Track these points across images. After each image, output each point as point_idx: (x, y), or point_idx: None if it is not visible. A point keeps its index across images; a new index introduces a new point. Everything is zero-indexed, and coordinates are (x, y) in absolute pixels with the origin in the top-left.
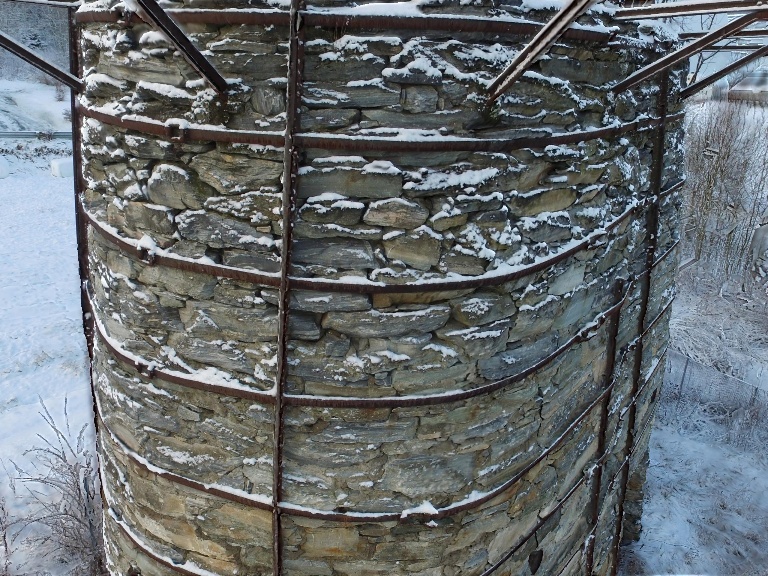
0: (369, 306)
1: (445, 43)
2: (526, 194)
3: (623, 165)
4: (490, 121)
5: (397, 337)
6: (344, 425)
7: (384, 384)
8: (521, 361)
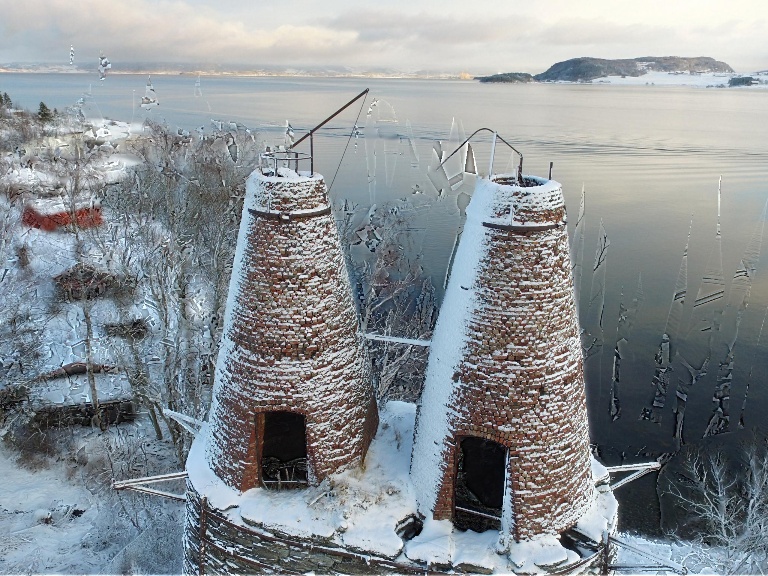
0: None
1: None
2: None
3: None
4: None
5: None
6: None
7: None
8: None
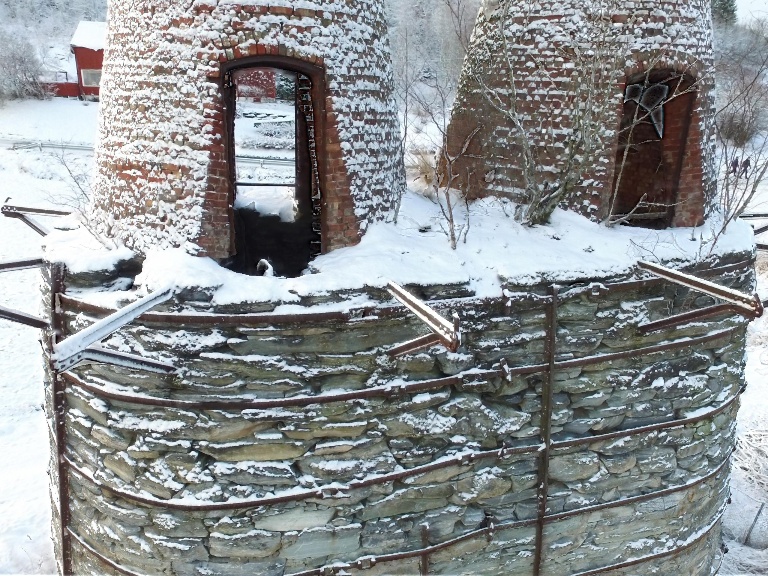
0: (99, 492)
1: (137, 327)
2: (220, 445)
3: (427, 419)
4: (177, 386)
5: (118, 520)
6: (93, 565)
7: (110, 549)
8: (221, 575)
